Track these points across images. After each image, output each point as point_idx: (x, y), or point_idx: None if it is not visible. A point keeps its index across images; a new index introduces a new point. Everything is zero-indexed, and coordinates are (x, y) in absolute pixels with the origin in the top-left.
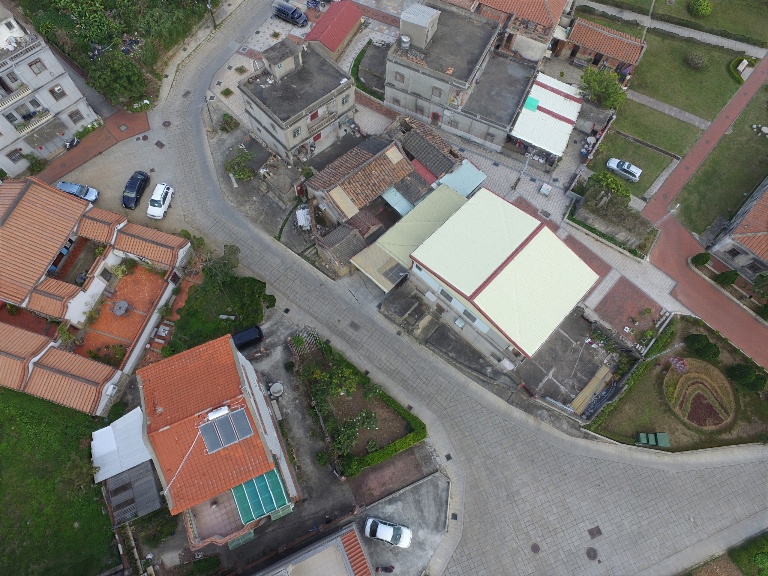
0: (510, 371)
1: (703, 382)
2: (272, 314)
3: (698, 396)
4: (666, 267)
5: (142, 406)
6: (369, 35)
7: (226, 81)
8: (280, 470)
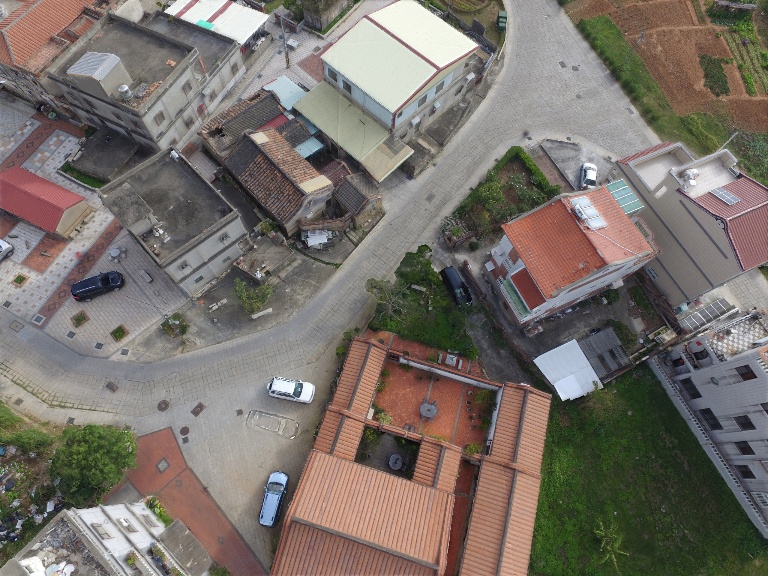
0: (466, 87)
1: None
2: None
3: None
4: None
5: (581, 281)
6: (48, 172)
7: (96, 337)
8: None
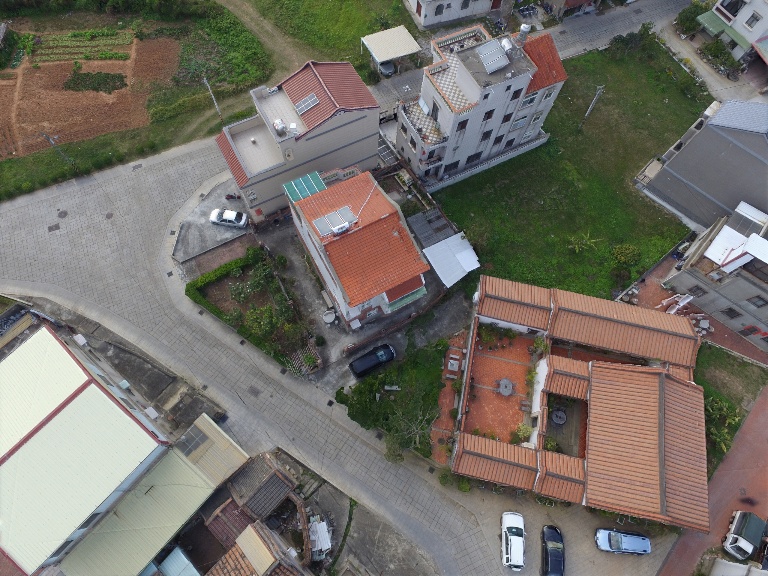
0: None
1: None
2: None
3: None
4: None
5: None
6: None
7: None
8: (297, 215)
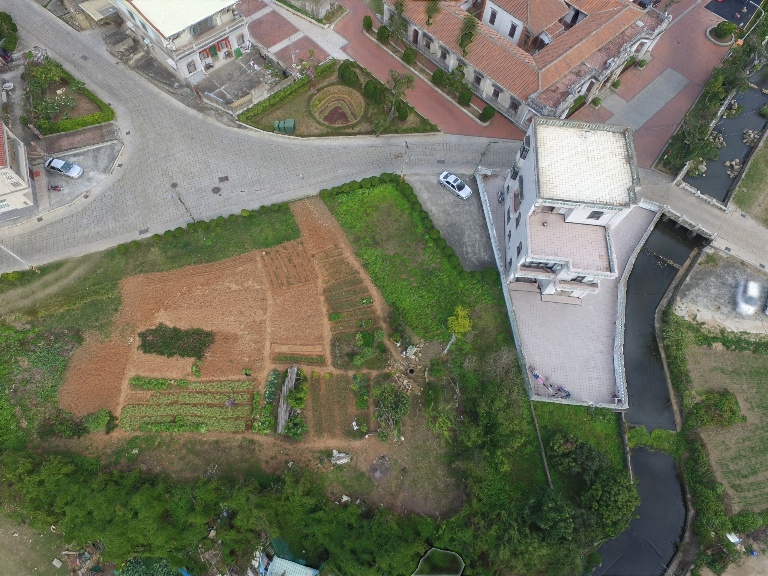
0: (185, 79)
1: (344, 100)
2: (24, 48)
3: (336, 107)
4: (345, 33)
5: None
6: None
7: None
8: None
